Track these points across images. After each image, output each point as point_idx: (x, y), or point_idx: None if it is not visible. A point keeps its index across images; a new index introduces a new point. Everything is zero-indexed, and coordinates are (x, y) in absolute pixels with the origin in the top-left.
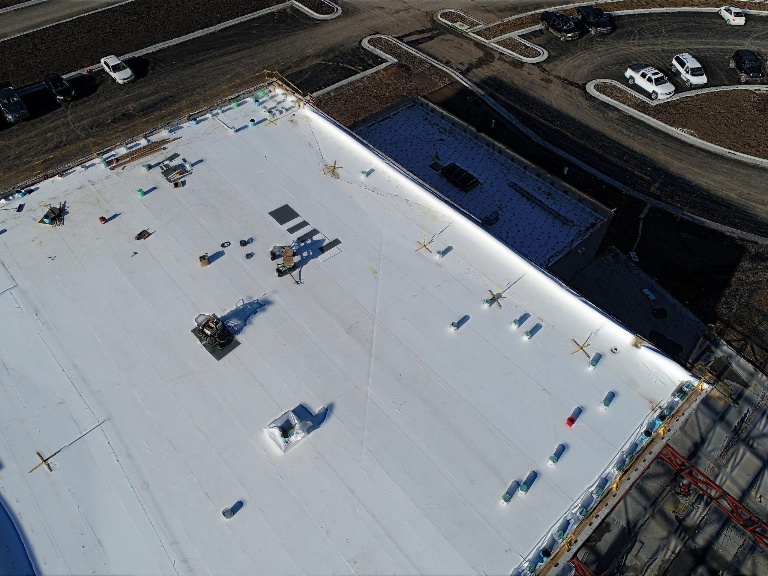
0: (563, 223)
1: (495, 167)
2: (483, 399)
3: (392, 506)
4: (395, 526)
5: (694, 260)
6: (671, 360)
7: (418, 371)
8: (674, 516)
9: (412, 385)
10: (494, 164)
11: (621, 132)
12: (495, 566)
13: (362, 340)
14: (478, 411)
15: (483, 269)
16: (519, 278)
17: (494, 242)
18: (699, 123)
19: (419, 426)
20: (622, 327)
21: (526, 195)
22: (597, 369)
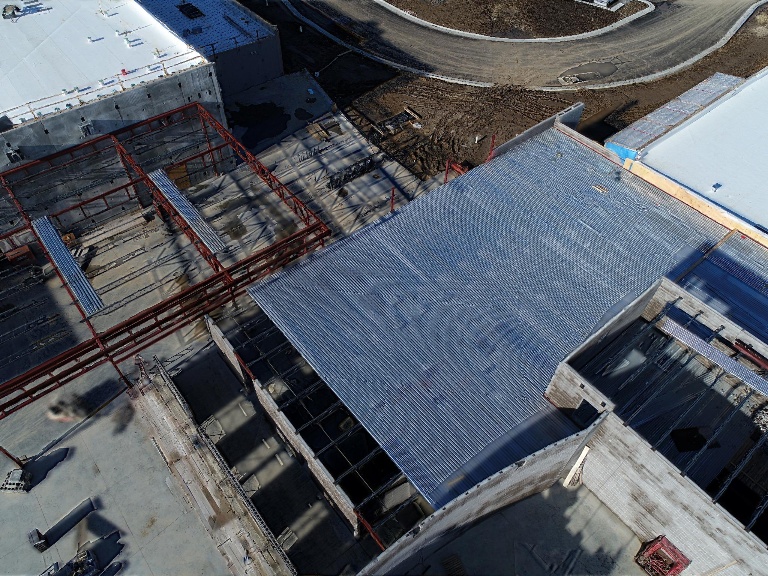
0: (244, 35)
1: (221, 8)
2: (85, 65)
3: (6, 93)
4: (3, 98)
5: (358, 78)
6: (196, 52)
7: (57, 54)
8: (250, 184)
9: (49, 58)
10: (221, 7)
11: (362, 12)
12: (43, 111)
13: (34, 43)
14: (78, 68)
15: (129, 22)
16: (146, 26)
17: (140, 9)
18: (423, 8)
19: (41, 71)
20: (182, 41)
21: (231, 22)
22: (159, 59)
